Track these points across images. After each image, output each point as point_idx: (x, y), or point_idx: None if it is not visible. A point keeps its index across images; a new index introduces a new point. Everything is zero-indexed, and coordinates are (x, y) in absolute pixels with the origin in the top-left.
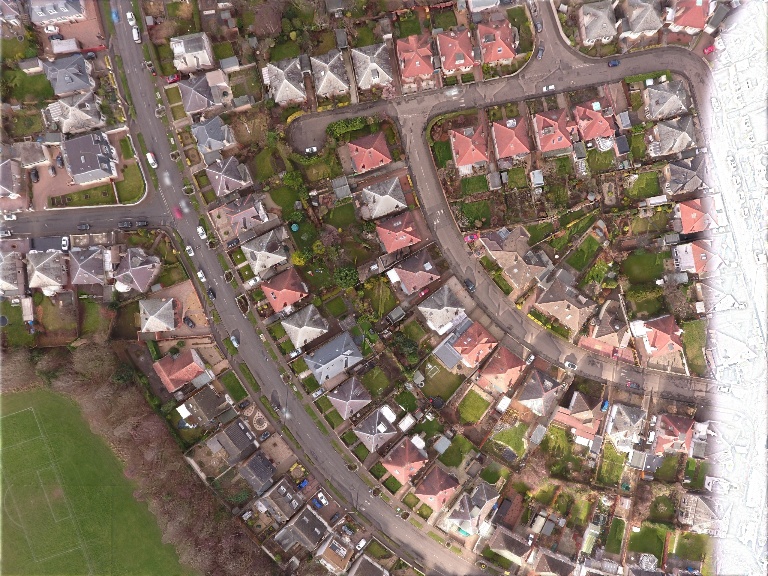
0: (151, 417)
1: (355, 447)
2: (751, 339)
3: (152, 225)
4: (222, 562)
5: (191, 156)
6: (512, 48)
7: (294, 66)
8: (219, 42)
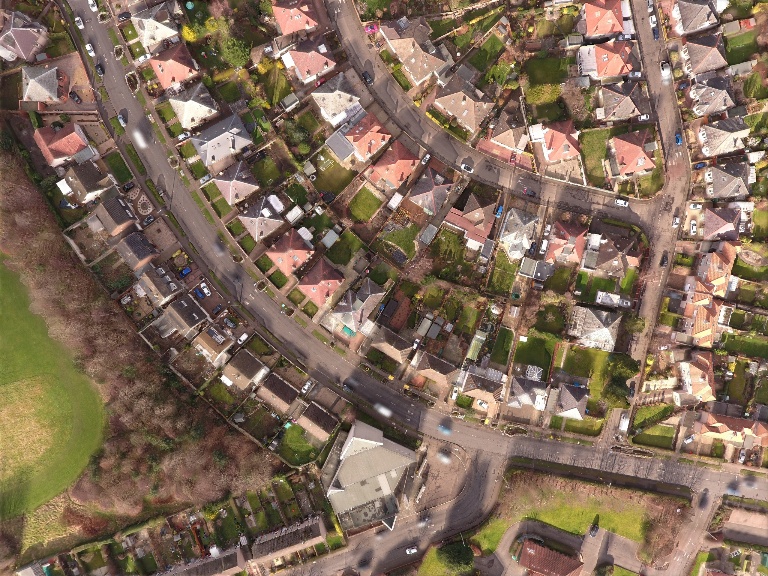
0: (31, 194)
1: (242, 238)
2: (648, 145)
3: None
4: (93, 337)
5: None
6: None
7: None
8: None
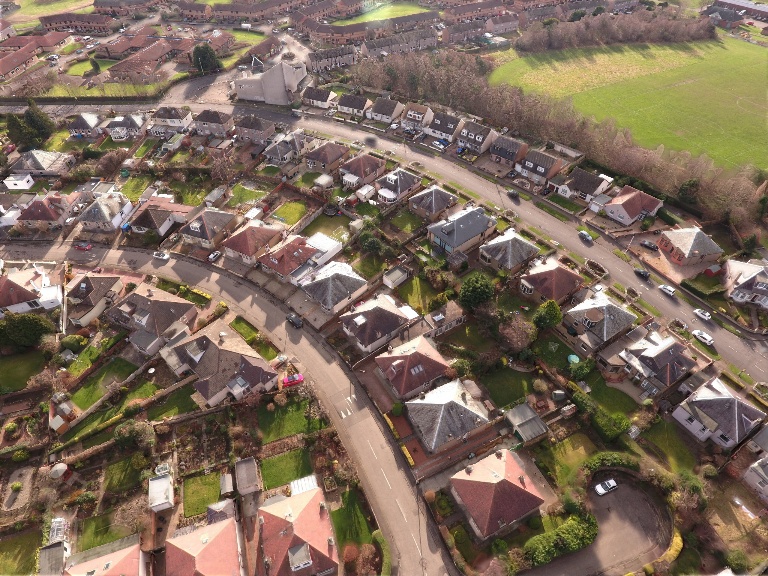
0: None
1: None
2: None
3: None
4: None
5: None
6: None
7: None
8: None
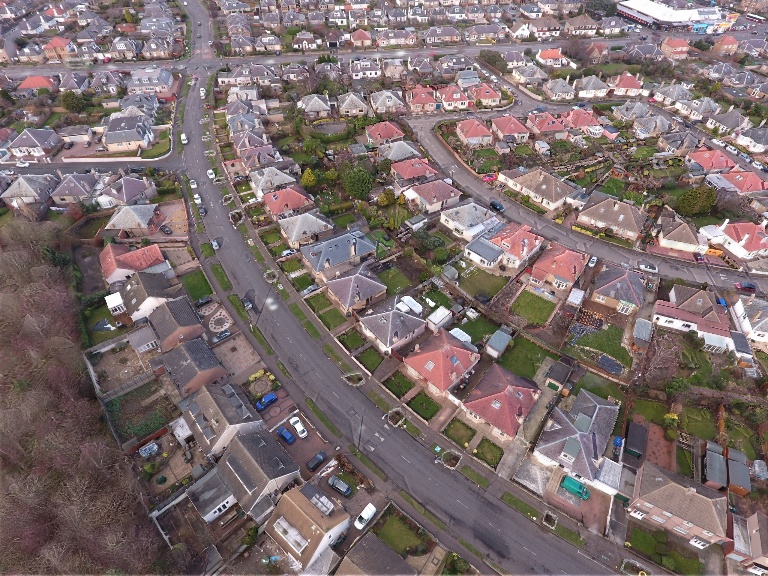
0: None
1: (360, 353)
2: None
3: (163, 171)
4: (60, 505)
5: (221, 139)
6: (497, 93)
7: (324, 97)
8: (267, 96)
